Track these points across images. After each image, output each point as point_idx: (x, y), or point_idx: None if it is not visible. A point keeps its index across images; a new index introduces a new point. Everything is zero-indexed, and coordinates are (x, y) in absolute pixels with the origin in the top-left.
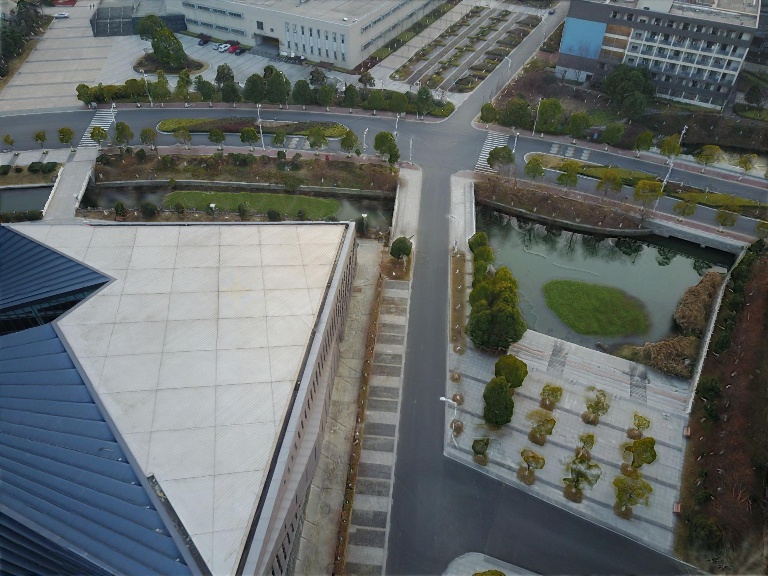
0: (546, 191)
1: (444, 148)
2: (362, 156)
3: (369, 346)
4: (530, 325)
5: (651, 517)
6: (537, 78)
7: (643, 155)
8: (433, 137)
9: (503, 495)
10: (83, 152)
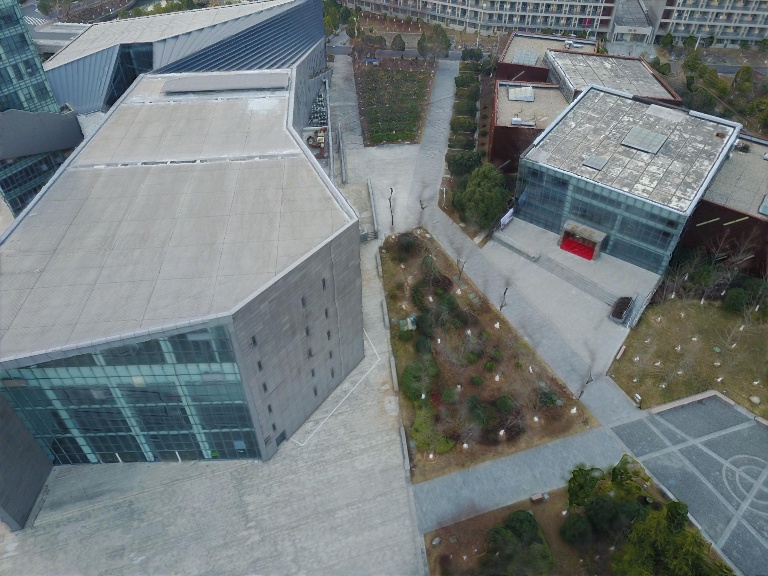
0: None
1: None
2: None
3: None
4: None
5: None
6: None
7: None
8: None
9: None
10: None
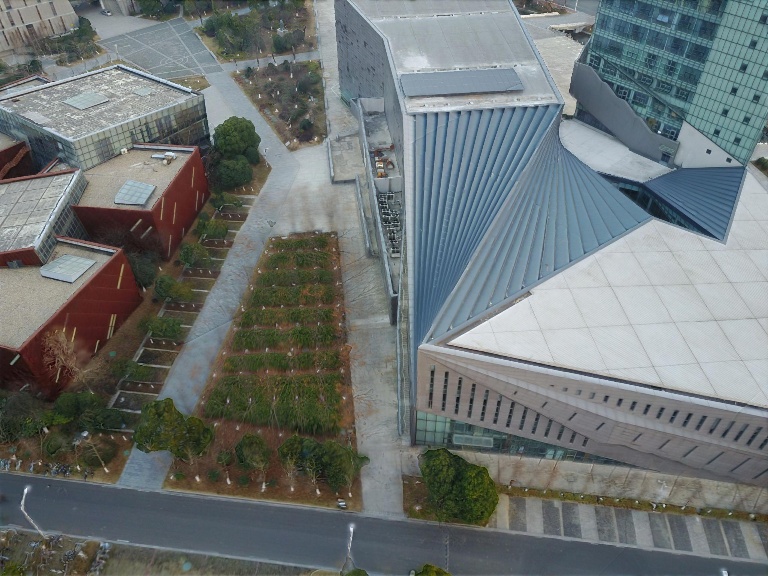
0: None
1: None
2: None
3: None
4: None
5: None
6: None
7: None
8: None
9: None
10: None
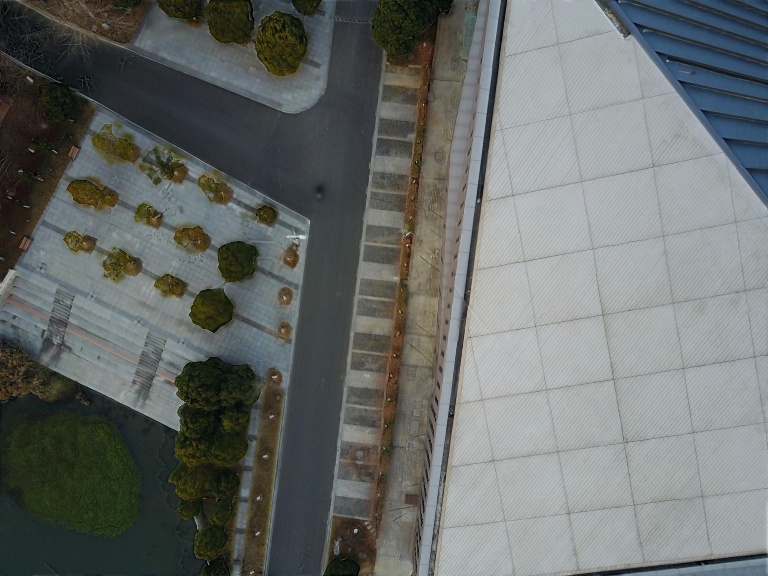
0: None
1: None
2: None
3: (394, 383)
4: (171, 441)
5: None
6: None
7: None
8: None
9: (252, 171)
10: None
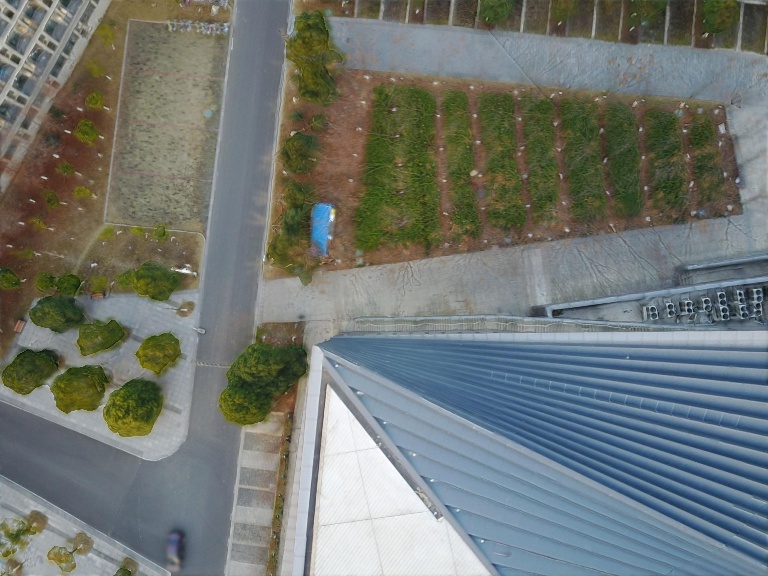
0: None
1: None
2: None
3: None
4: None
5: None
6: None
7: None
8: None
9: (112, 522)
10: None
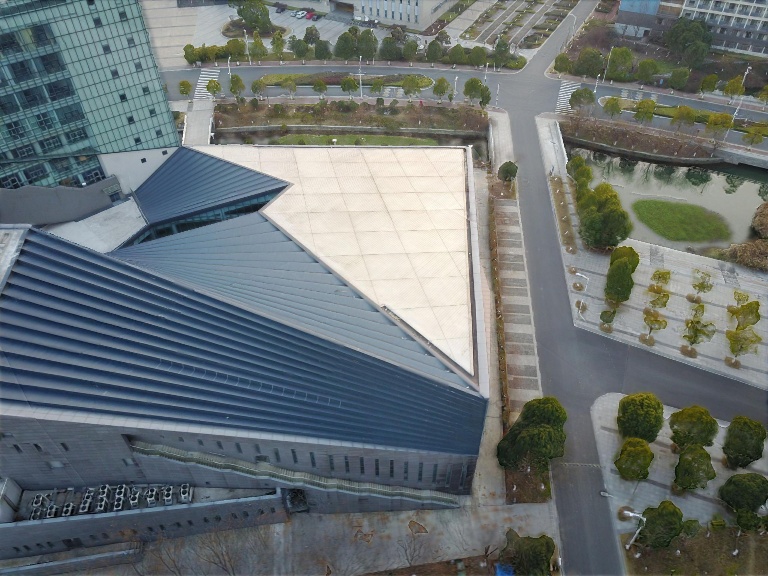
0: (623, 128)
1: (524, 94)
2: (451, 102)
3: (493, 248)
4: None
5: (757, 367)
6: (600, 33)
7: (707, 97)
8: (512, 86)
9: (630, 353)
10: (199, 103)
